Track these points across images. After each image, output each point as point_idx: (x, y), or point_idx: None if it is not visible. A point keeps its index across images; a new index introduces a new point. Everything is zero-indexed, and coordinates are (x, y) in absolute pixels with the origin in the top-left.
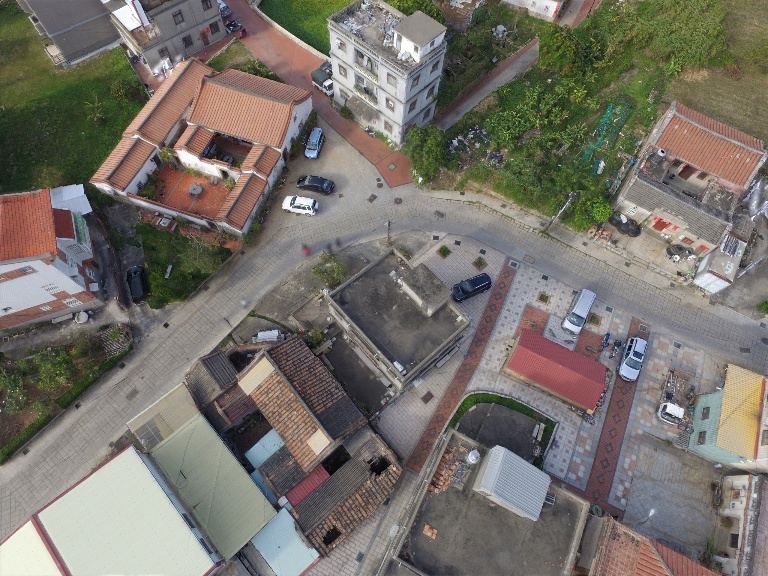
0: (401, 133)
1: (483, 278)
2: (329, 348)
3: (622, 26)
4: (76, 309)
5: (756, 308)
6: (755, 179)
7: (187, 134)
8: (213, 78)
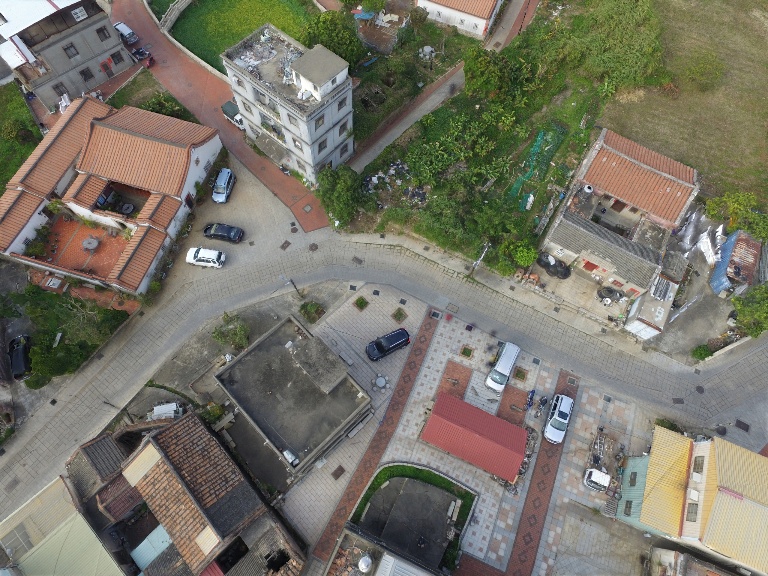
0: (314, 173)
1: (400, 334)
2: (231, 422)
3: (554, 44)
4: None
5: (690, 353)
6: (691, 208)
7: (77, 184)
8: (105, 120)
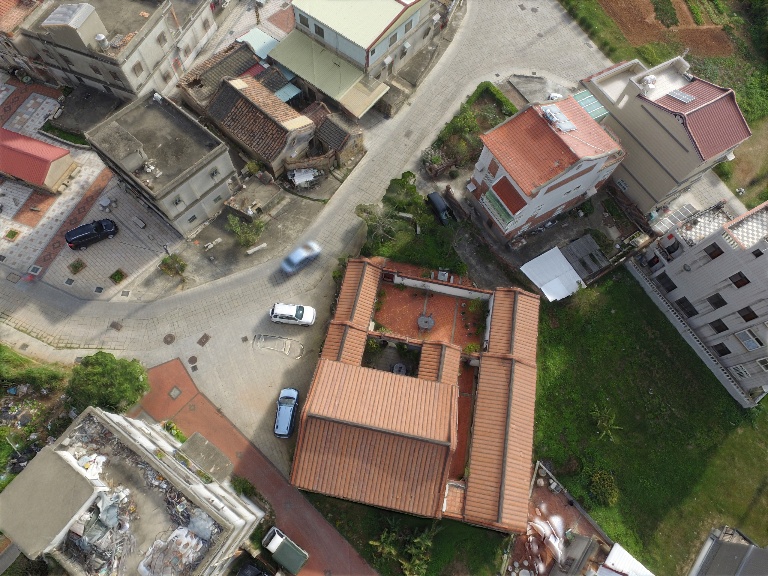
0: None
1: (73, 235)
2: None
3: None
4: None
5: None
6: None
7: (451, 369)
8: (442, 461)
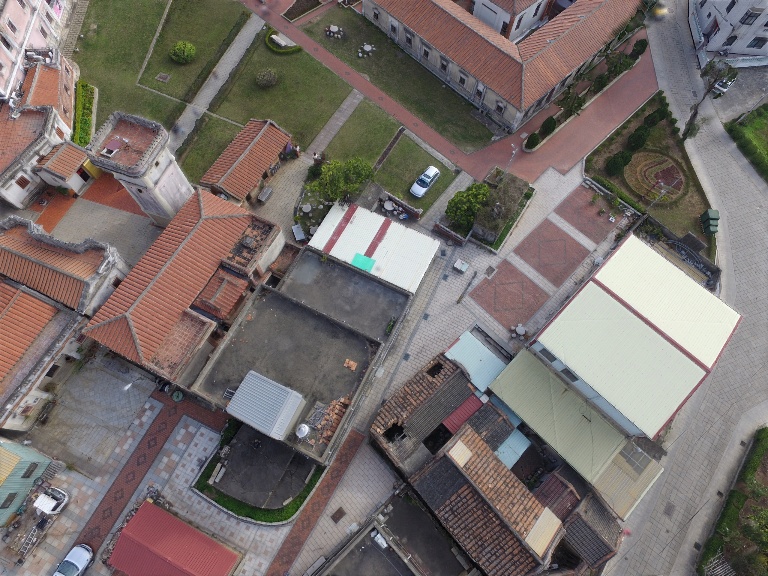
0: None
1: None
2: None
3: None
4: None
5: None
6: None
7: None
8: None
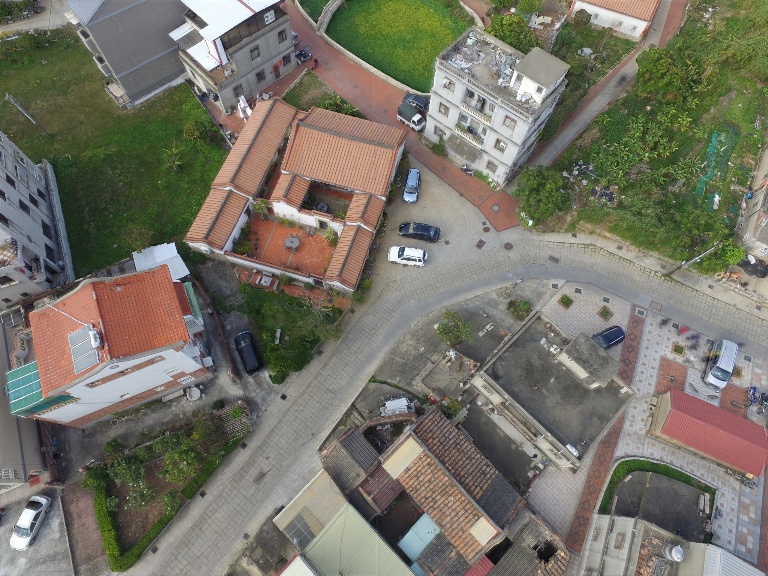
0: (507, 173)
1: (617, 332)
2: (465, 417)
3: (717, 46)
4: (187, 385)
5: None
6: None
7: (283, 184)
8: (305, 121)
